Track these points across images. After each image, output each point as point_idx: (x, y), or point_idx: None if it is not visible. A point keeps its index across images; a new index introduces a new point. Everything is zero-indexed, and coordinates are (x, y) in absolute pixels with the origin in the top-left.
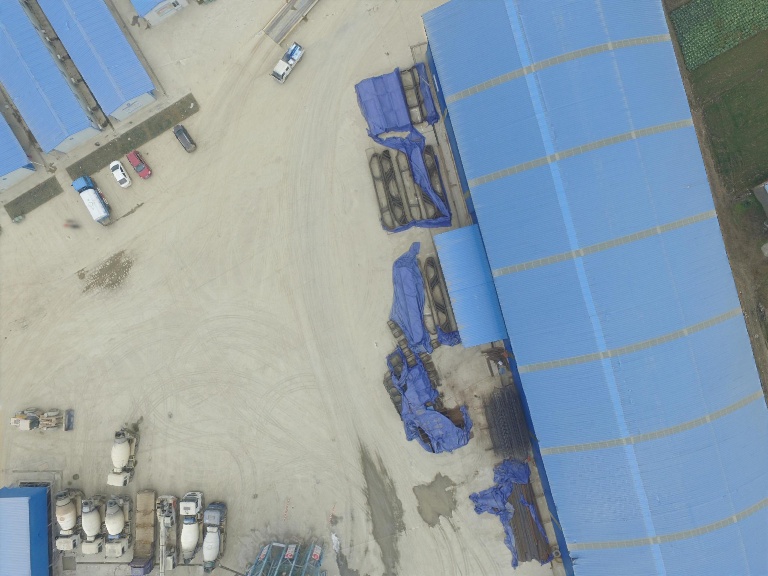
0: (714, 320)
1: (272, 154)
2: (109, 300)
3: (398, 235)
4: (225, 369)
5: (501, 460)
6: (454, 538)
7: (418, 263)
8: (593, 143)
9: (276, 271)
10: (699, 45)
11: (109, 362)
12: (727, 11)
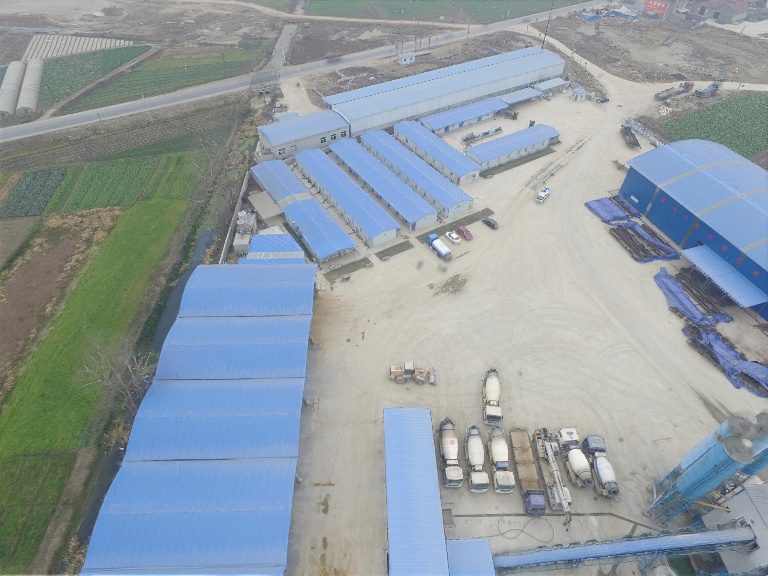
0: None
1: (546, 230)
2: (454, 300)
3: (648, 264)
4: (556, 340)
5: None
6: None
7: (671, 276)
8: (760, 189)
9: (572, 283)
10: None
11: (460, 337)
12: None
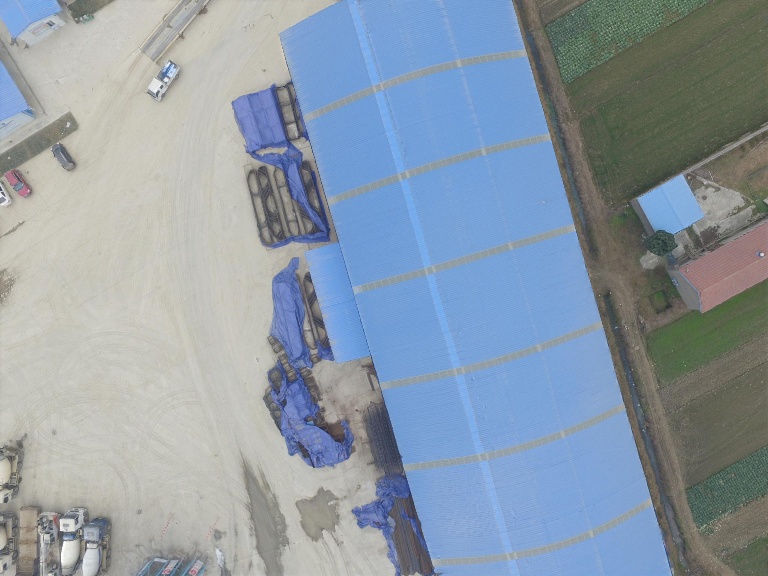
0: (570, 335)
1: (151, 171)
2: None
3: (277, 251)
4: (108, 385)
5: (383, 474)
6: (337, 552)
7: (297, 278)
8: (442, 160)
9: (157, 288)
10: (574, 58)
11: None
12: (602, 24)
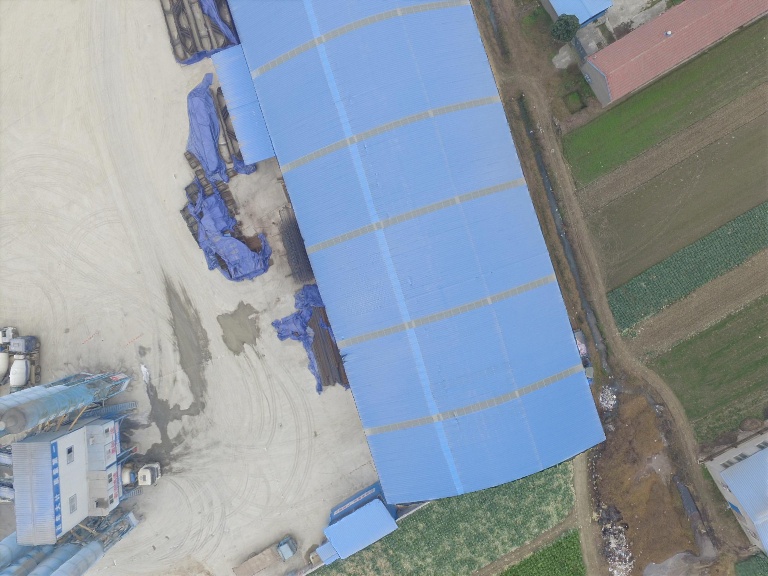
0: (465, 104)
1: None
2: None
3: (191, 67)
4: (33, 207)
5: (301, 286)
6: (259, 365)
7: (211, 93)
8: None
9: (76, 109)
10: None
11: None
12: None
